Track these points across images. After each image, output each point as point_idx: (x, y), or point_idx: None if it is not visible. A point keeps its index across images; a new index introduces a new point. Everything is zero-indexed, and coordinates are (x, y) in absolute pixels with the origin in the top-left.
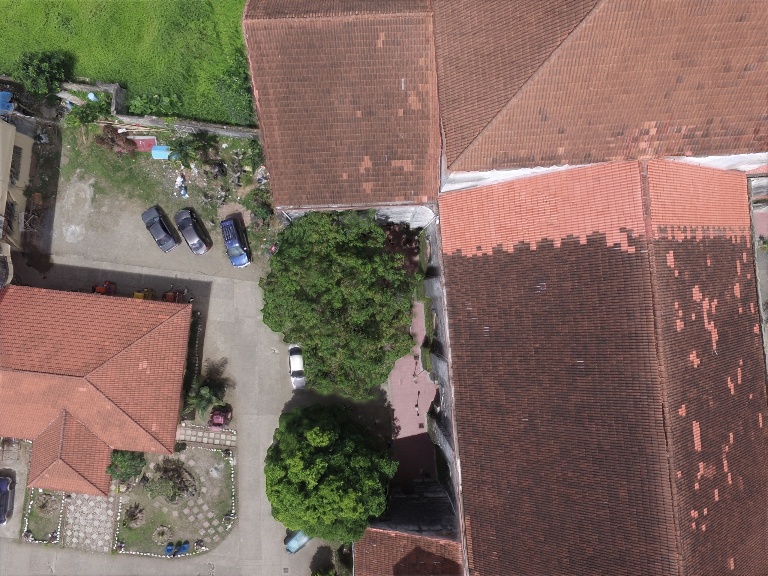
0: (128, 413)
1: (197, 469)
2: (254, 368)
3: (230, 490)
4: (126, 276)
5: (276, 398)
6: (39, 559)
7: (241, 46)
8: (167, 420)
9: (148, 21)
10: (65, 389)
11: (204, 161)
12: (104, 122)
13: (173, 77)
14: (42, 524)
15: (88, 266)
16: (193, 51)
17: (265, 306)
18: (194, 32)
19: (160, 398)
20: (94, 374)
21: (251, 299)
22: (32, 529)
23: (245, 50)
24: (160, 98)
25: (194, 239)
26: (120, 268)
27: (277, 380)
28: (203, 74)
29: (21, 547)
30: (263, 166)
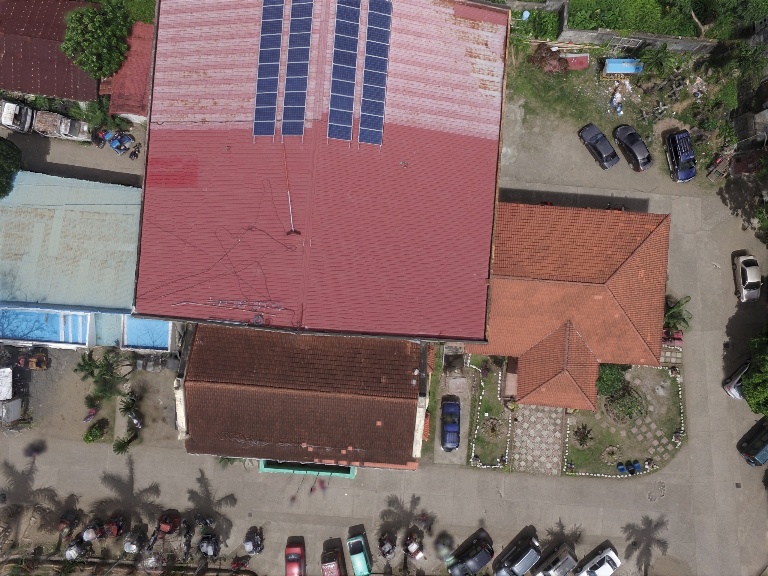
0: (633, 322)
1: (643, 388)
2: (696, 284)
3: (678, 407)
4: (561, 196)
5: (720, 313)
6: (487, 484)
7: None
8: (656, 330)
9: None
10: (580, 298)
11: (640, 76)
12: (535, 41)
13: None
14: (489, 449)
15: (521, 188)
16: None
17: (761, 210)
18: None
19: (652, 308)
20: (611, 281)
21: (690, 215)
22: (479, 454)
23: None
24: (602, 12)
25: (642, 154)
26: (554, 189)
27: (720, 295)
28: None
29: (468, 473)
30: (698, 80)
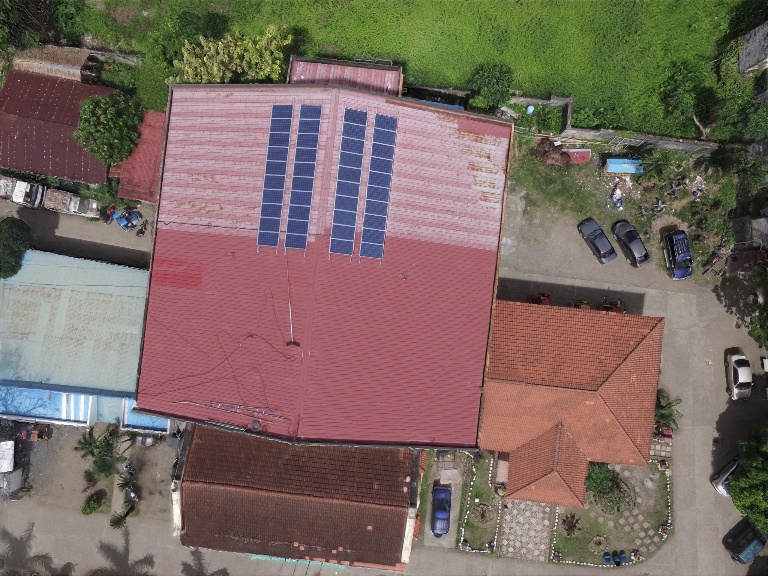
0: (623, 426)
1: (632, 479)
2: (688, 379)
3: (665, 500)
4: (559, 288)
5: (710, 409)
6: (475, 568)
7: (677, 59)
8: (646, 432)
9: (583, 34)
10: (571, 403)
11: (641, 174)
12: (539, 135)
13: (618, 90)
14: (478, 534)
15: (520, 278)
16: (633, 64)
17: (754, 320)
18: (631, 45)
19: (643, 411)
20: (603, 388)
21: (685, 311)
22: (468, 539)
23: (691, 63)
24: (605, 111)
25: (640, 252)
26: (552, 280)
27: (711, 391)
28: (639, 87)
29: (457, 556)
30: (698, 179)
